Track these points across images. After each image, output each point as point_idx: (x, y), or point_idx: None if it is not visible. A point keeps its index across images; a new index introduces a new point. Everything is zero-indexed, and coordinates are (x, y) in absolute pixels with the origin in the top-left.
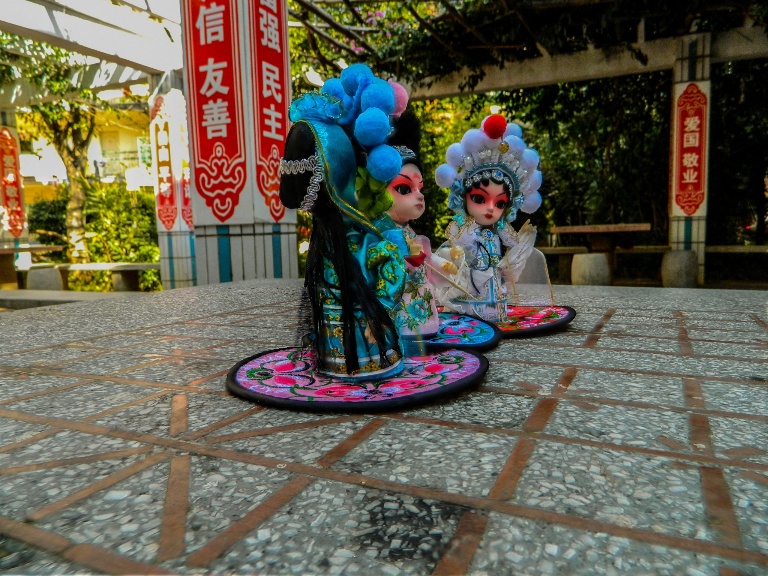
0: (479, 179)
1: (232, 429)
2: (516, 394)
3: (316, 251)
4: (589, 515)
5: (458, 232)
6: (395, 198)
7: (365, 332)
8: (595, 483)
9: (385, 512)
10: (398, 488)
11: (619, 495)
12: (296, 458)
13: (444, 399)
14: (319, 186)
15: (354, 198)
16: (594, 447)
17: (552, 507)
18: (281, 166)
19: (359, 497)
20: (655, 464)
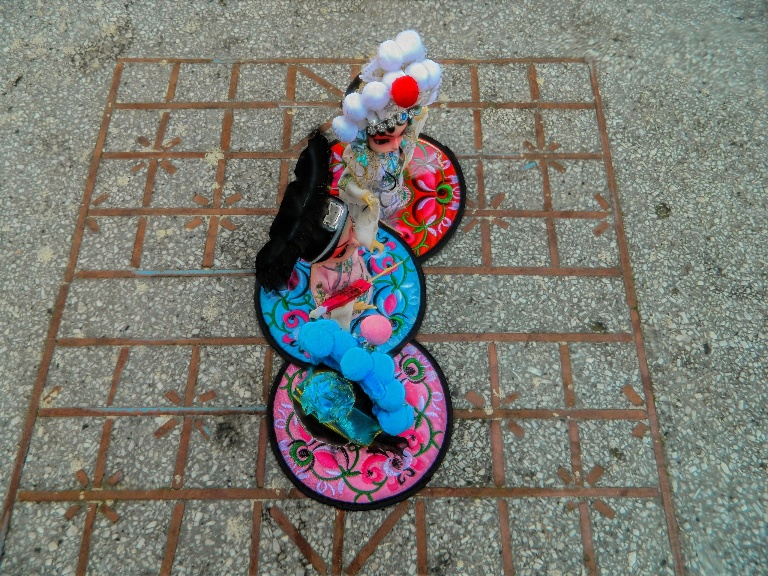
0: (384, 130)
1: (350, 553)
2: (474, 419)
3: None
4: (545, 575)
5: (364, 173)
6: (336, 261)
7: None
8: (542, 542)
9: None
10: None
11: (552, 550)
12: (407, 575)
13: None
14: None
15: None
16: (533, 498)
17: (531, 575)
18: None
19: None
20: (561, 508)
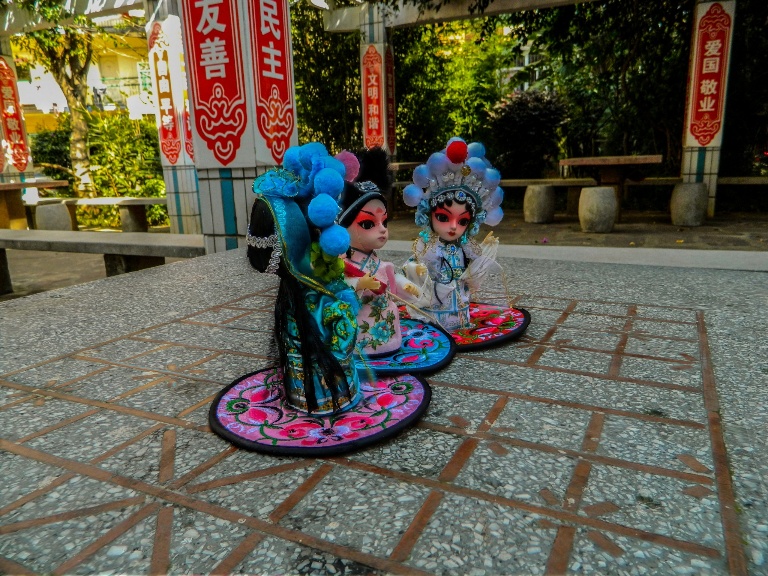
0: (443, 200)
1: (208, 476)
2: (447, 432)
3: (281, 306)
4: None
5: (424, 248)
6: (360, 233)
7: (321, 381)
8: (474, 543)
9: (311, 572)
10: (325, 547)
11: (487, 556)
12: (254, 512)
13: (385, 440)
14: (279, 259)
15: (310, 268)
16: (487, 501)
17: (433, 569)
18: (247, 238)
19: (295, 556)
20: (527, 522)
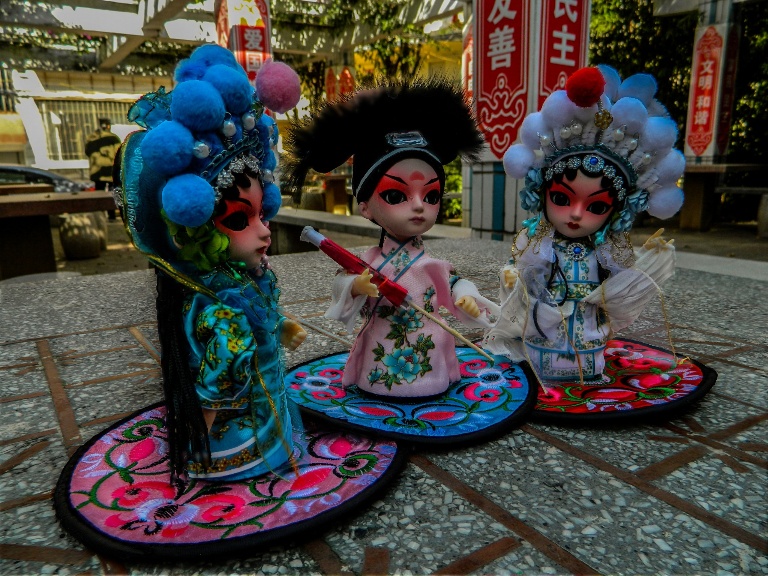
0: (561, 169)
1: None
2: None
3: None
4: None
5: (526, 246)
6: (382, 209)
7: None
8: None
9: None
10: None
11: None
12: None
13: (221, 557)
14: (135, 227)
15: (174, 245)
16: None
17: None
18: None
19: None
20: None
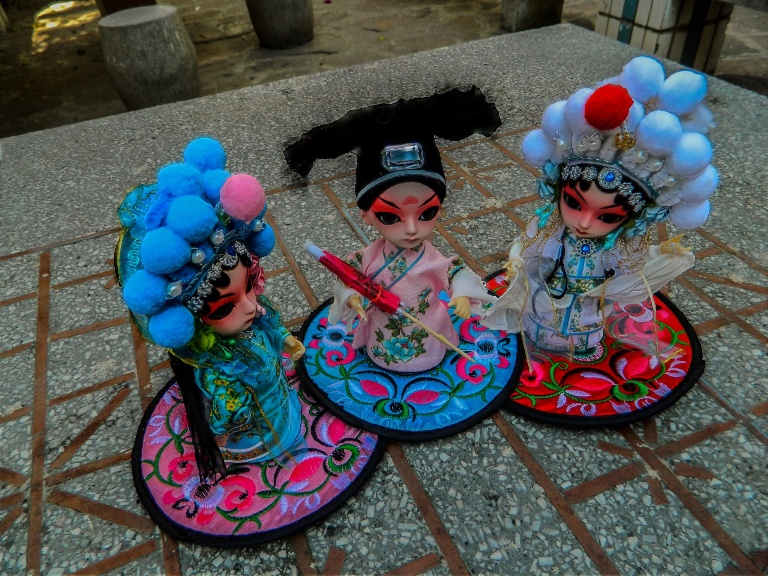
0: (576, 177)
1: (78, 485)
2: None
3: None
4: None
5: (535, 235)
6: (377, 225)
7: None
8: None
9: None
10: None
11: None
12: (47, 568)
13: None
14: None
15: None
16: None
17: None
18: None
19: None
20: None
